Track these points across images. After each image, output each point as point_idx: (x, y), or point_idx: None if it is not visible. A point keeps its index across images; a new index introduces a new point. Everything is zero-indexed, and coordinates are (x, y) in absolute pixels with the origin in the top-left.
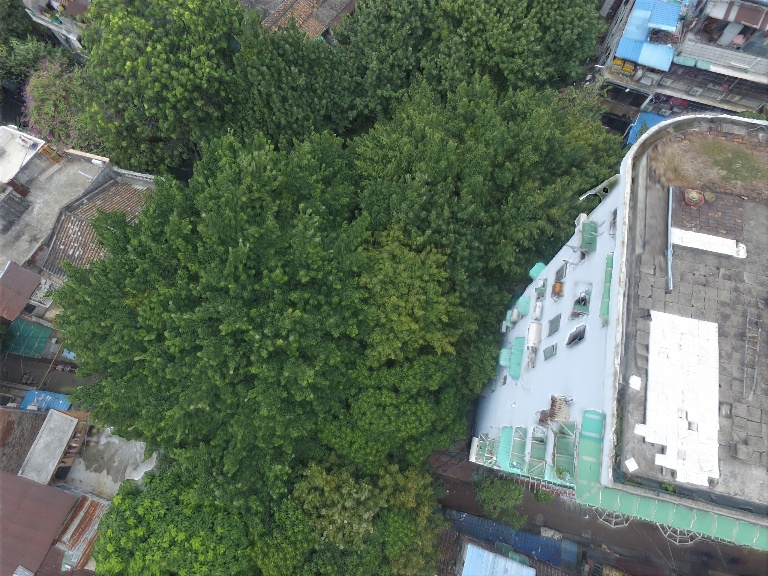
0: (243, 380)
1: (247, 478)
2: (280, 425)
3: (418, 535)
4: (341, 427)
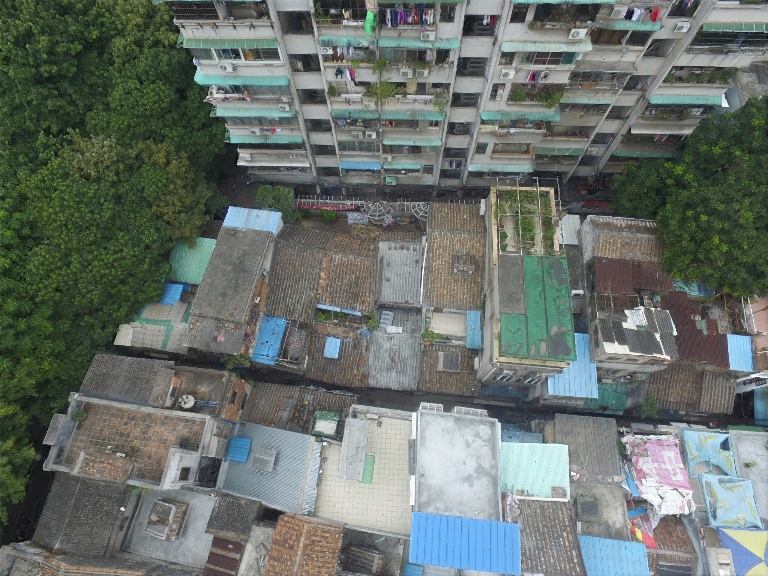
0: (4, 72)
1: (19, 148)
2: (35, 95)
3: (172, 184)
4: (99, 113)
